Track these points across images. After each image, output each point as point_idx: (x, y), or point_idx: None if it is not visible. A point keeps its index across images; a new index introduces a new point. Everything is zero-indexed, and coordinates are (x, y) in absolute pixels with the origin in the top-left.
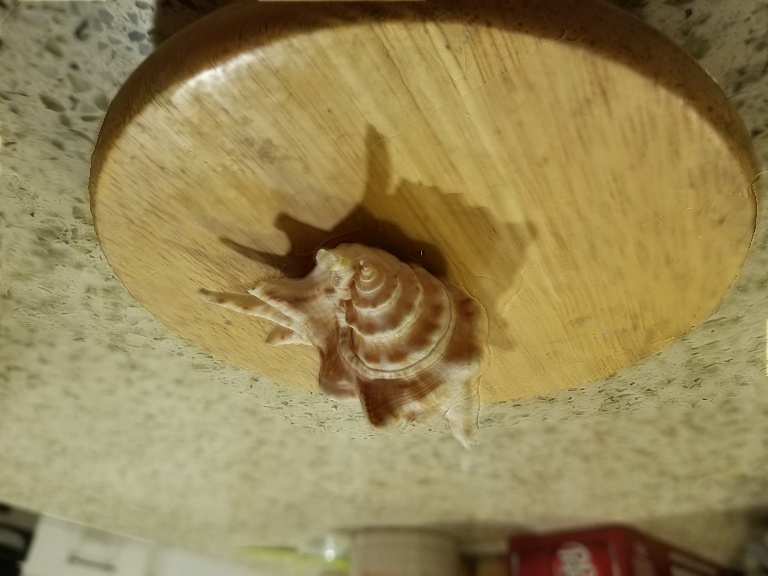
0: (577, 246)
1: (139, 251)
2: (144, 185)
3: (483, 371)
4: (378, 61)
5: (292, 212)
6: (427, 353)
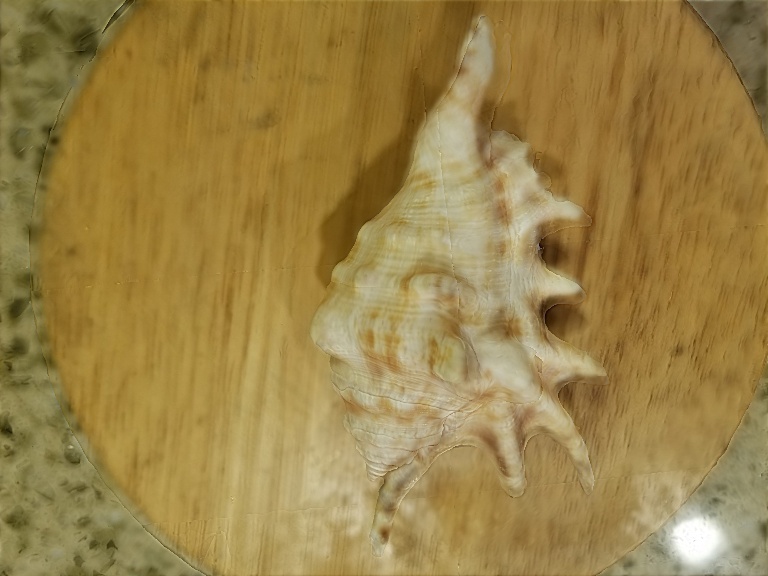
0: (212, 281)
1: (630, 508)
2: (532, 571)
3: (323, 321)
4: (268, 572)
5: (442, 479)
6: (364, 395)
